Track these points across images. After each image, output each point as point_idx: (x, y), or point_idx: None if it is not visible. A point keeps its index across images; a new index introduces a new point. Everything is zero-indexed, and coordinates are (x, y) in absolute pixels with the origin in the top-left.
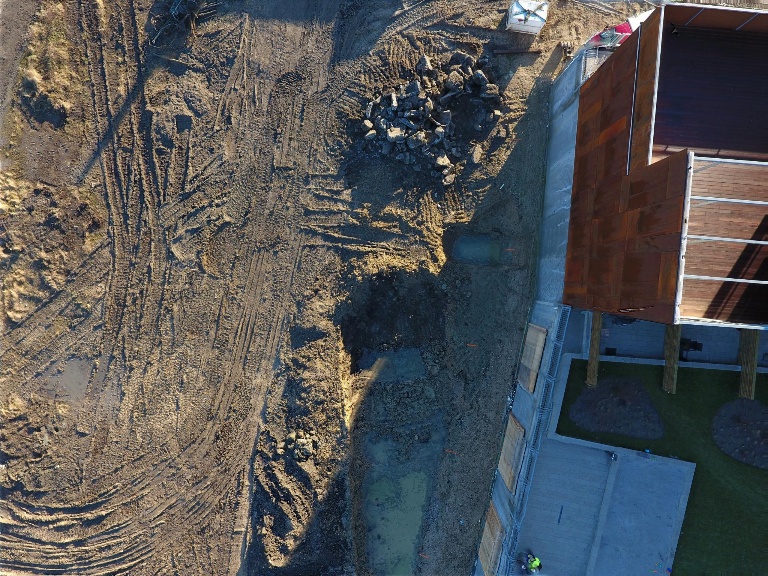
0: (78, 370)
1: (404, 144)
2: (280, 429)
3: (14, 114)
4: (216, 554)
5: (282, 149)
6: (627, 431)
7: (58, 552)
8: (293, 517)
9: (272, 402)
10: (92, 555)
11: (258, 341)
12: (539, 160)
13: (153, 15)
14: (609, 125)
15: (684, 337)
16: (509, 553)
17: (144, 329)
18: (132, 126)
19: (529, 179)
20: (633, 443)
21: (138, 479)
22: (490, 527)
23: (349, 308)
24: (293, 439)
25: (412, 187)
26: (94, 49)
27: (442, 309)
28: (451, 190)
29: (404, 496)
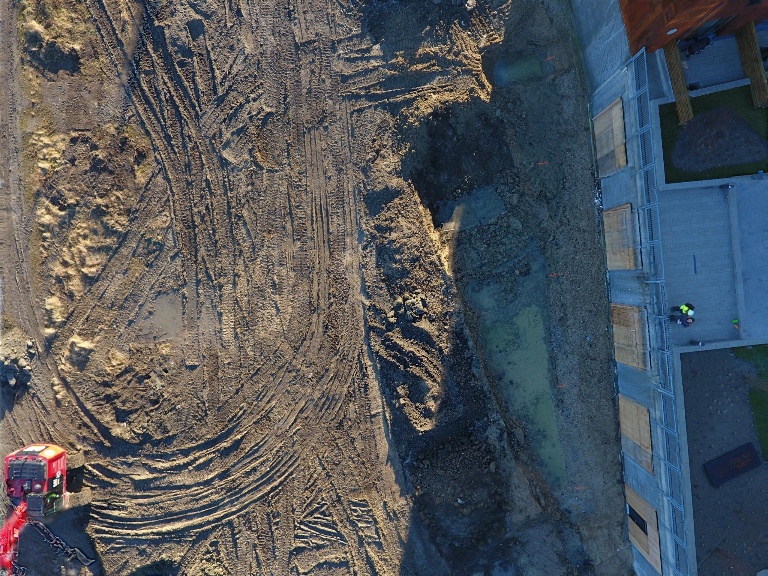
0: (168, 306)
1: None
2: (385, 299)
3: (27, 72)
4: (361, 443)
5: (300, 25)
6: (734, 161)
7: (205, 491)
8: (426, 378)
9: (368, 276)
10: (240, 482)
11: (336, 221)
12: None
13: None
14: None
15: (762, 45)
16: (660, 314)
17: (221, 244)
18: (147, 47)
19: None
20: (744, 169)
21: (261, 393)
22: (622, 323)
23: (414, 159)
24: (401, 303)
25: (438, 21)
26: None
27: (502, 137)
28: (476, 15)
29: (523, 335)
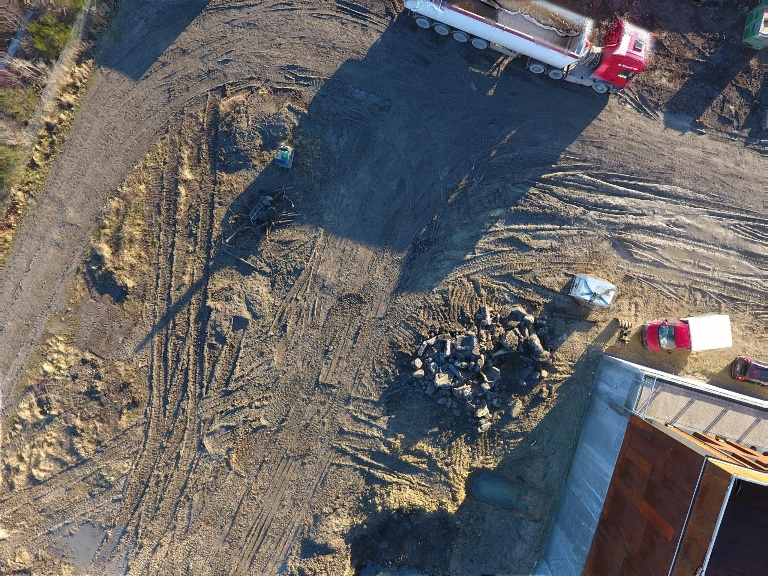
0: (89, 536)
1: (449, 390)
2: None
3: (77, 281)
4: None
5: (330, 366)
6: None
7: None
8: None
9: None
10: None
11: (269, 543)
12: (574, 425)
13: (231, 213)
14: (655, 508)
15: None
16: None
17: (161, 511)
18: (189, 316)
19: (561, 441)
20: None
21: None
22: None
23: (363, 530)
24: None
25: (448, 429)
26: (167, 234)
27: (452, 541)
28: (484, 436)
29: None
